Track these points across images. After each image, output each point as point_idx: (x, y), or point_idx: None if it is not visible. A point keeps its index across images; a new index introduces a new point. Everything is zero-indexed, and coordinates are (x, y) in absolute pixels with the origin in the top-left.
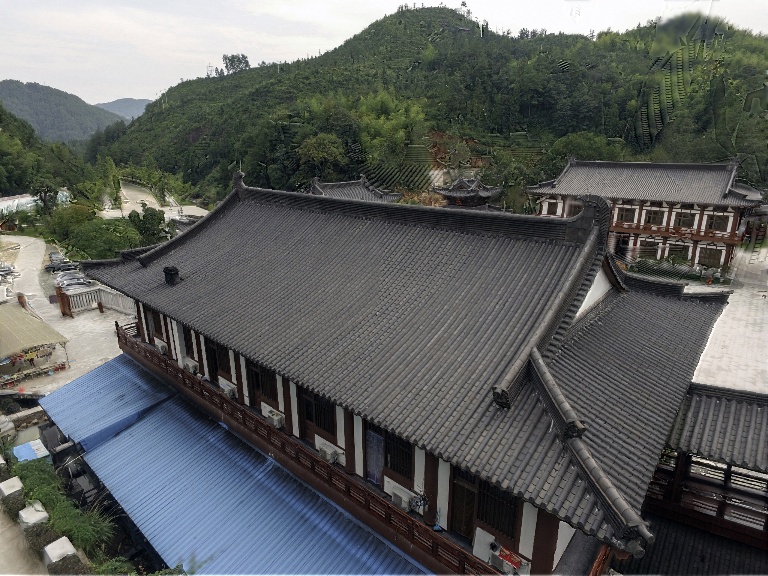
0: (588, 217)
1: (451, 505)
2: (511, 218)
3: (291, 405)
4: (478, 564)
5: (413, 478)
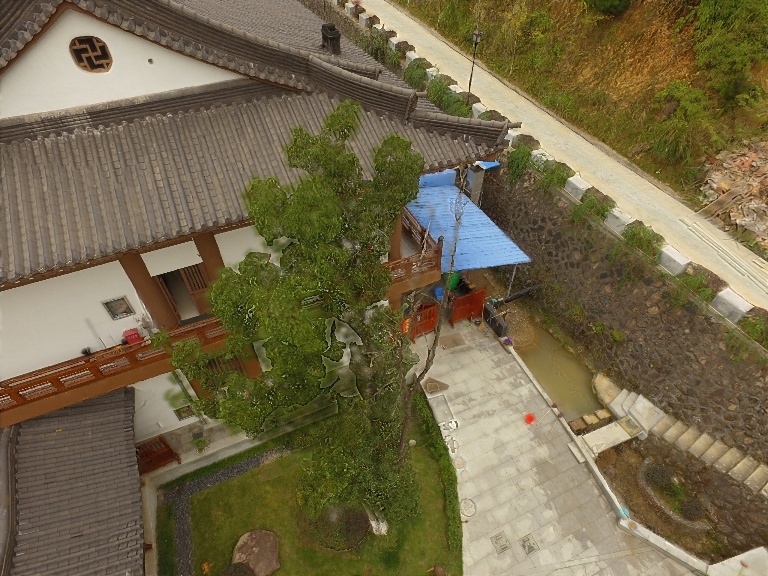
0: None
1: None
2: None
3: None
4: None
5: None
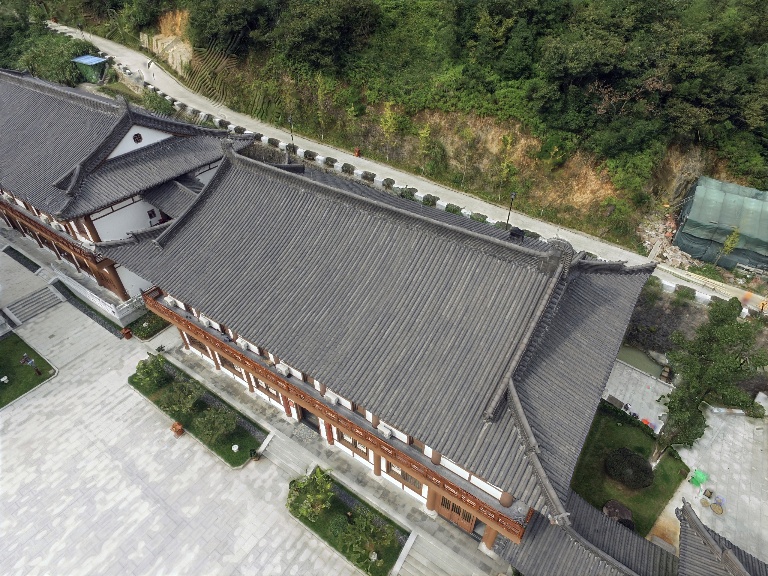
0: None
1: None
2: None
3: None
4: None
5: None
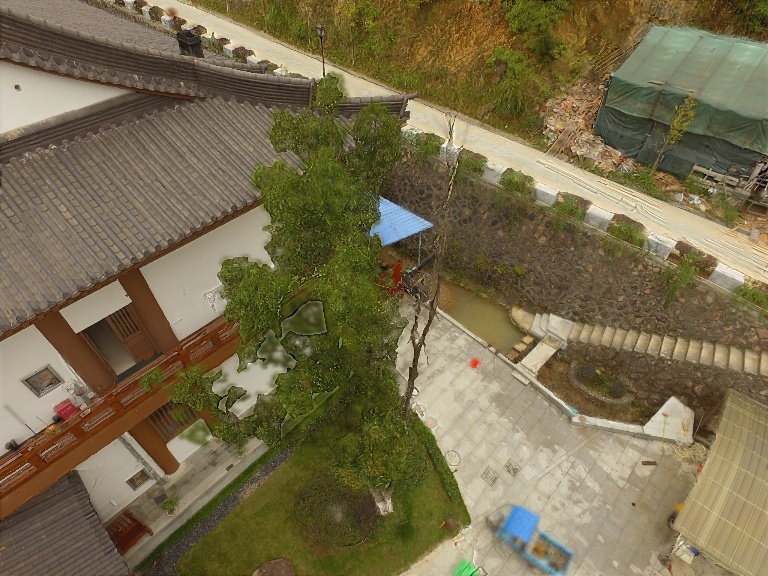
0: None
1: None
2: None
3: None
4: None
5: None
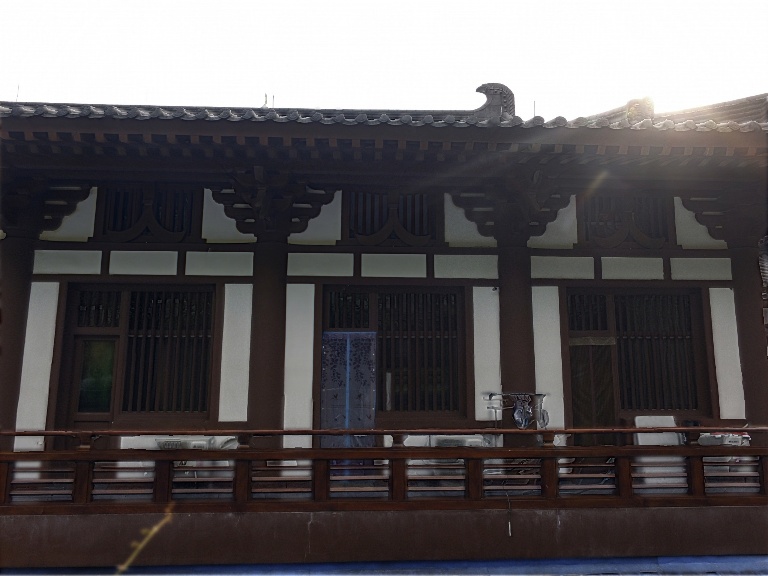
0: (495, 104)
1: (571, 401)
2: (406, 112)
3: (21, 377)
4: (725, 444)
5: (472, 387)
